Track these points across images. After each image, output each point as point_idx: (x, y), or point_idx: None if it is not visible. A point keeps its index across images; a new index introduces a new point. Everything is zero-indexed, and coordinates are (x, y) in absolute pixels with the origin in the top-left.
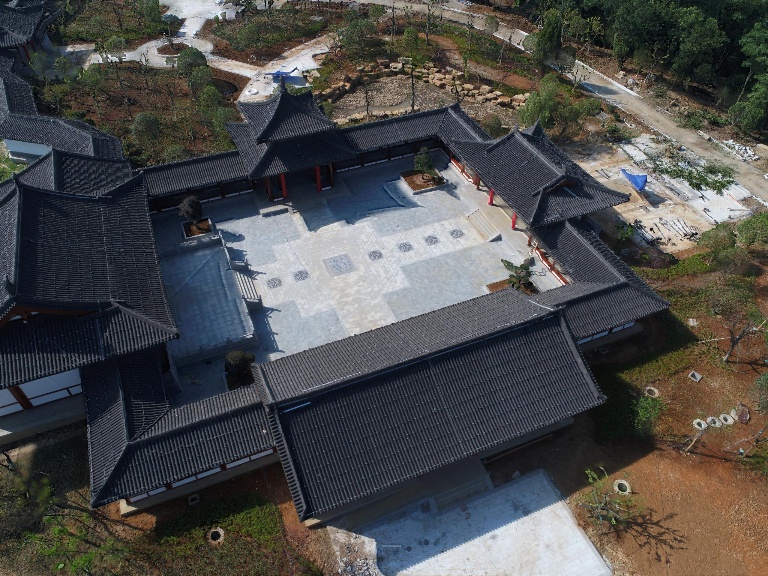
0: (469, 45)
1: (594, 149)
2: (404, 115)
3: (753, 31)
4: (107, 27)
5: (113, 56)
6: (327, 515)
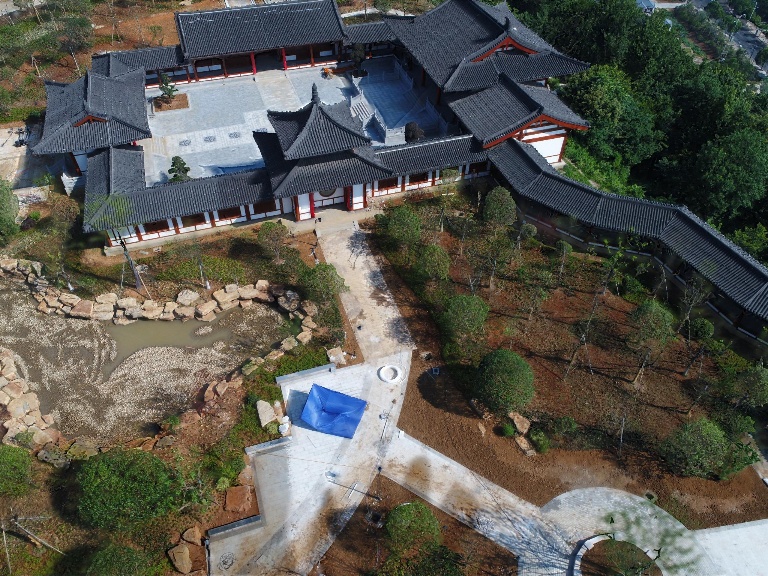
0: None
1: None
2: (168, 215)
3: None
4: None
5: None
6: None
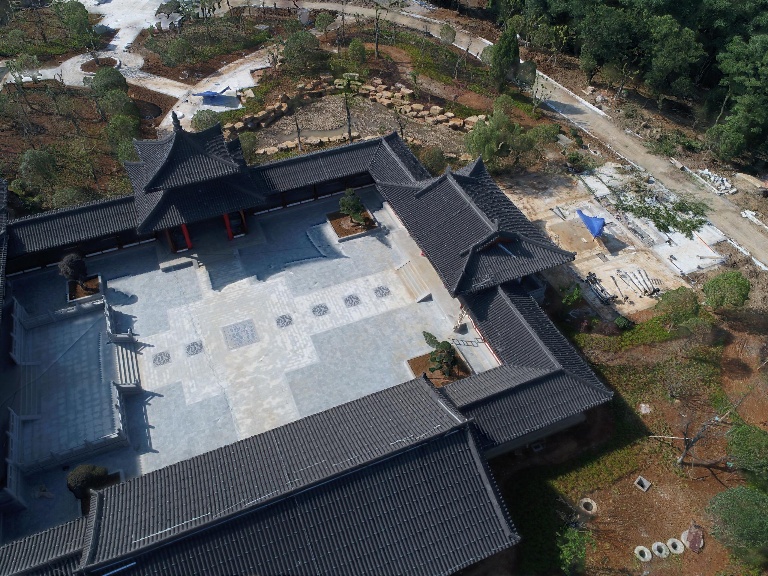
0: (422, 58)
1: (551, 182)
2: (334, 147)
3: (732, 46)
4: (30, 40)
5: (26, 76)
6: None
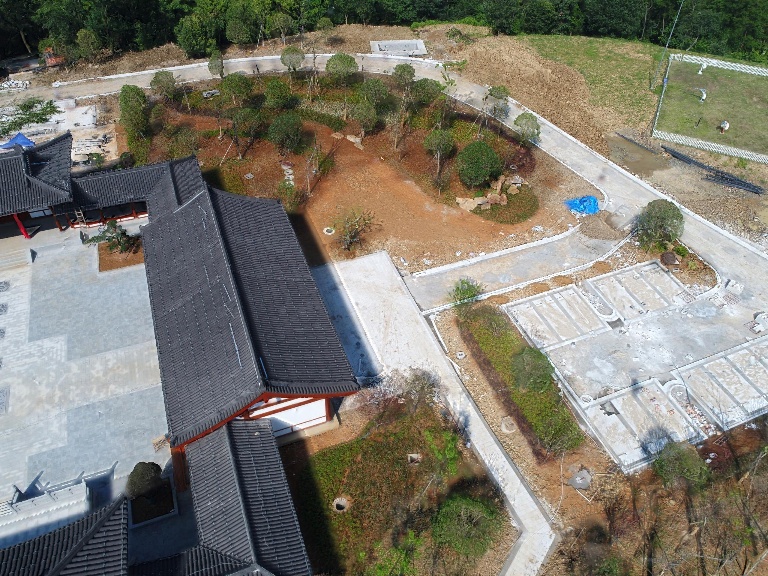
0: None
1: None
2: None
3: None
4: None
5: None
6: (331, 409)
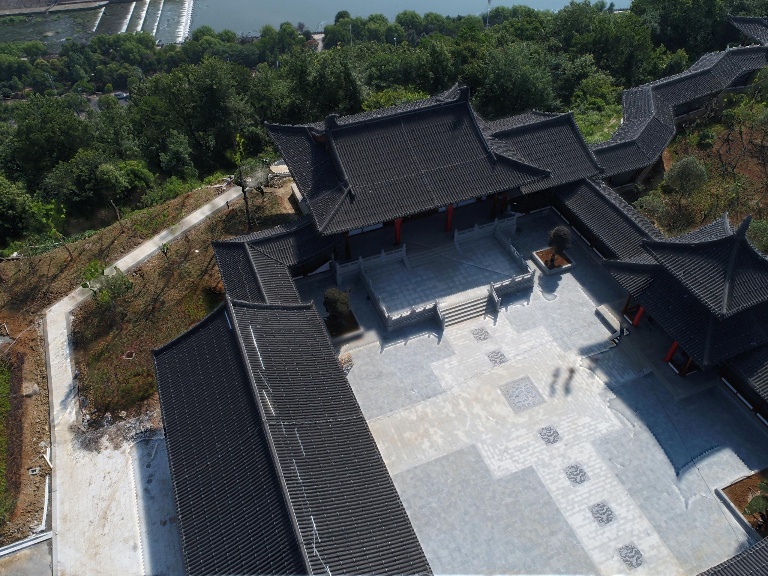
0: None
1: None
2: None
3: None
4: None
5: None
6: None
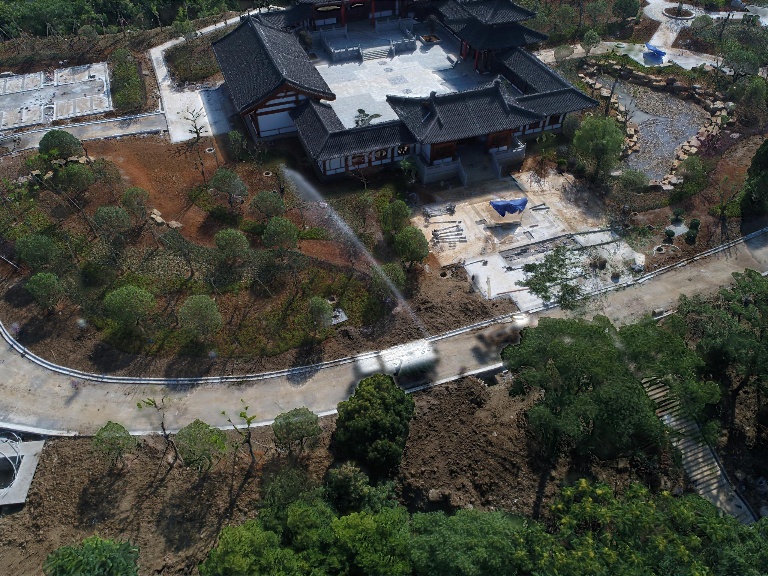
0: None
1: (590, 211)
2: None
3: None
4: None
5: None
6: None
